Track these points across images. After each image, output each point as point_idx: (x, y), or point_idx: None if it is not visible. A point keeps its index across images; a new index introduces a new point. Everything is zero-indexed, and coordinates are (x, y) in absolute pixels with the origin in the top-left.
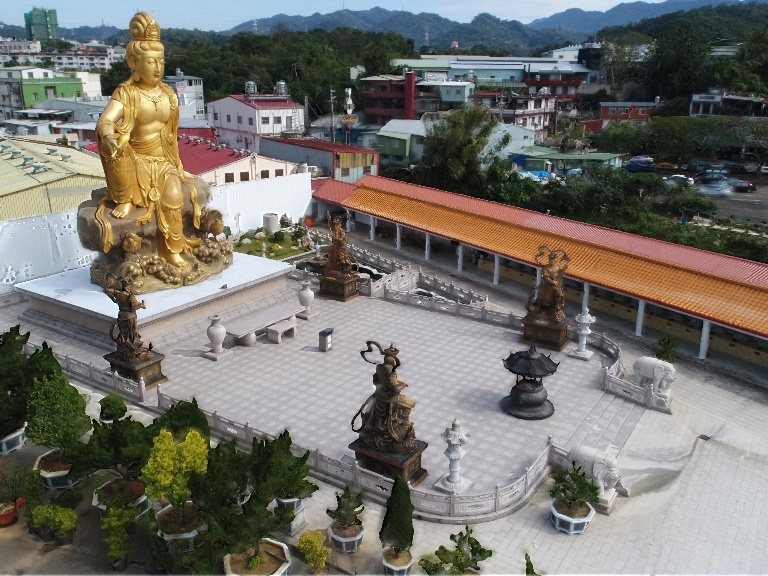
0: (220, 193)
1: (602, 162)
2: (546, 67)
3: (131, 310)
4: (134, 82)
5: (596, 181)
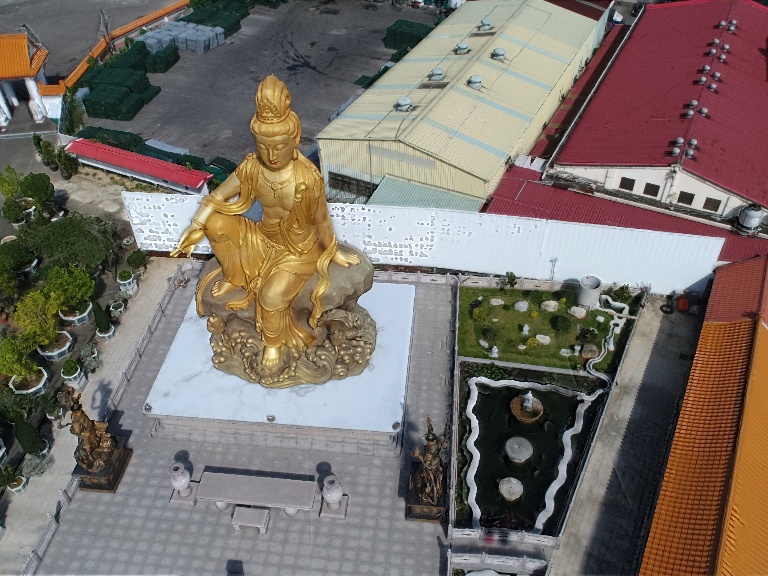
0: (534, 227)
1: None
2: None
3: None
4: None
5: None
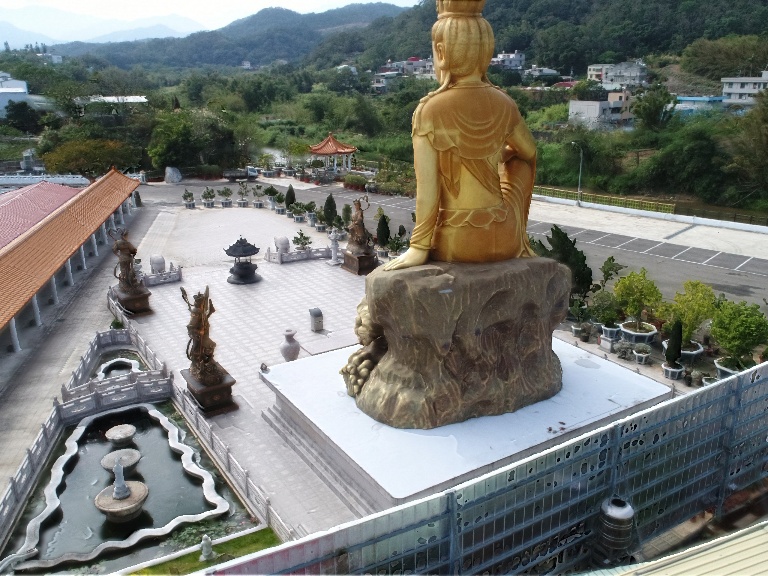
0: None
1: None
2: None
3: None
4: None
5: None
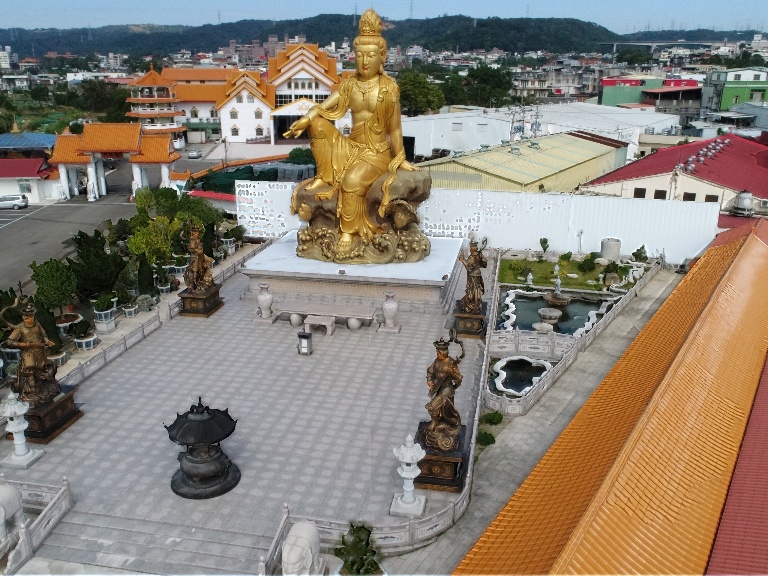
0: (562, 203)
1: None
2: None
3: None
4: (357, 74)
5: None
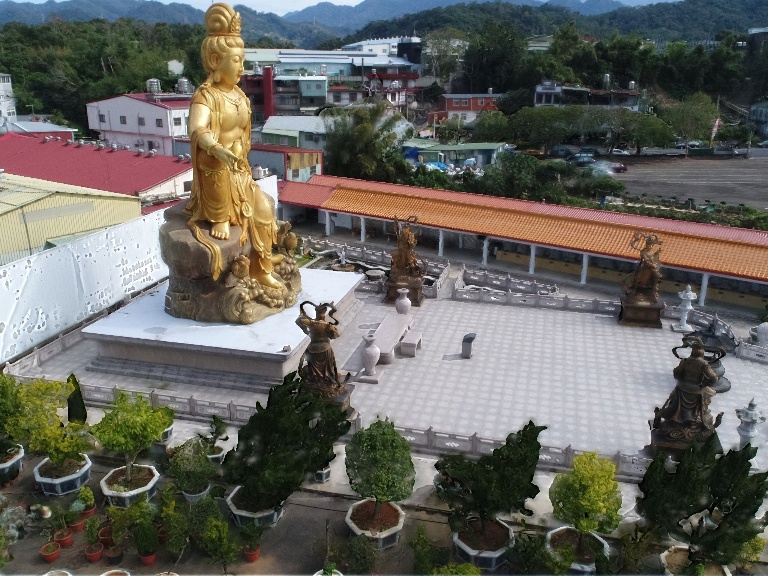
0: None
1: (493, 151)
2: (381, 61)
3: (327, 340)
4: (213, 83)
5: (512, 169)
